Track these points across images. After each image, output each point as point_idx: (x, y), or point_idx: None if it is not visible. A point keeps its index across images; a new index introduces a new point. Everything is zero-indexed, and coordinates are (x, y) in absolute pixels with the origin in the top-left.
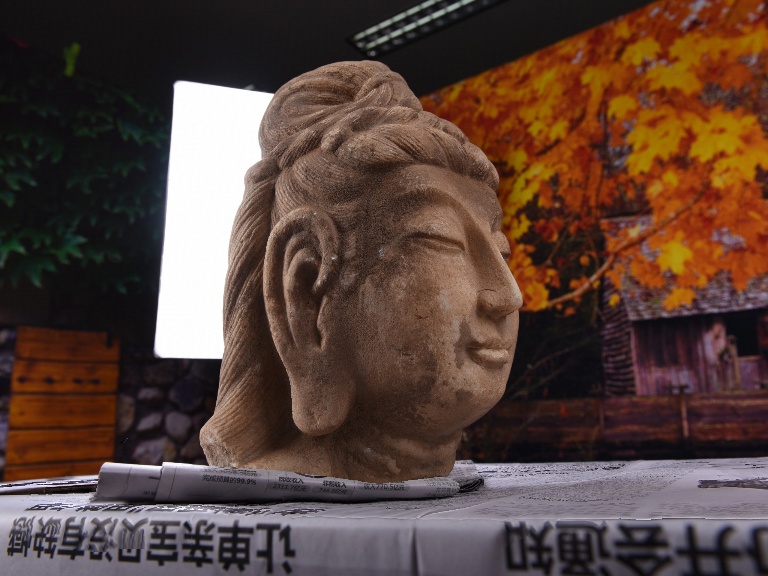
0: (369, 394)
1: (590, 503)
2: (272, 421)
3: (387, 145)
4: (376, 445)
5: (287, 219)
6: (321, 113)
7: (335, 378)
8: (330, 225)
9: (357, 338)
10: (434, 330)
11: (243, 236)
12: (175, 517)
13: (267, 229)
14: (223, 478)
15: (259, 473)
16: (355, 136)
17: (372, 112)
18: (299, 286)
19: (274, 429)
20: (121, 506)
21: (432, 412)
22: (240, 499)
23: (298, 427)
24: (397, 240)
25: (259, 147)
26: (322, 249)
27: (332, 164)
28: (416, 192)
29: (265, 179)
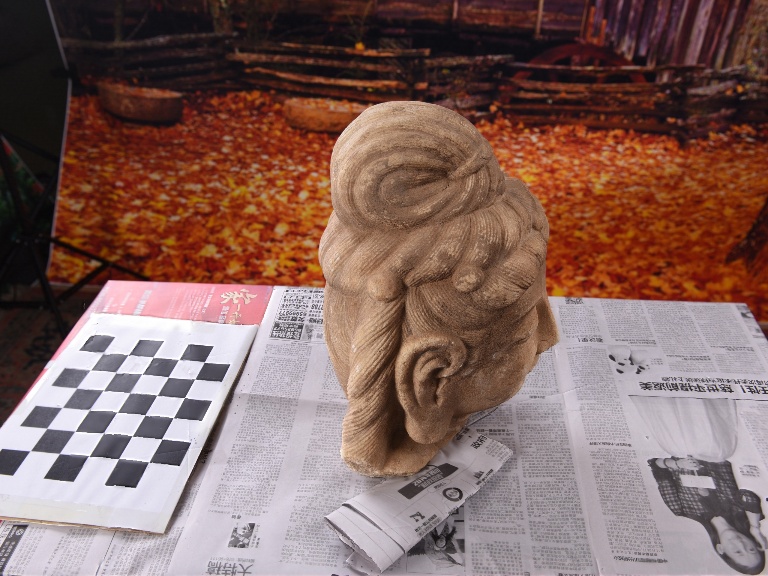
0: None
1: (652, 569)
2: None
3: (514, 292)
4: None
5: (427, 345)
6: (430, 212)
7: (445, 417)
8: None
9: (464, 396)
10: None
11: (382, 348)
12: None
13: (399, 337)
14: None
15: (439, 517)
16: (489, 283)
17: (496, 247)
18: (429, 378)
19: None
20: None
21: None
22: None
23: None
24: (506, 347)
25: (345, 211)
26: (453, 360)
27: (469, 306)
28: None
29: (396, 299)
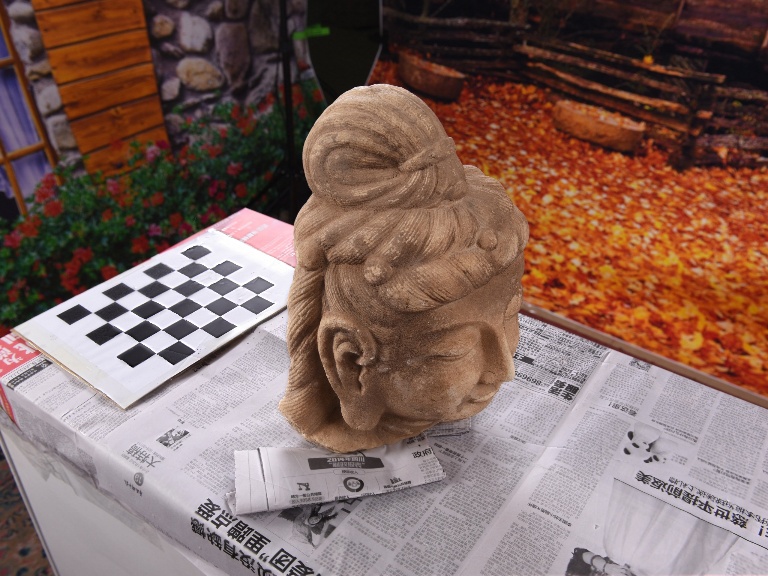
0: (394, 413)
1: None
2: (327, 404)
3: (420, 299)
4: (398, 425)
5: (336, 324)
6: (365, 196)
7: (371, 409)
8: (370, 340)
9: (387, 394)
10: (442, 405)
11: (300, 313)
12: None
13: (319, 309)
14: (303, 505)
15: (323, 496)
16: (394, 281)
17: (411, 248)
18: (346, 360)
19: (329, 408)
20: (253, 545)
21: None
22: None
23: None
24: (422, 358)
25: None
26: None
27: (373, 299)
28: (441, 329)
29: (315, 270)
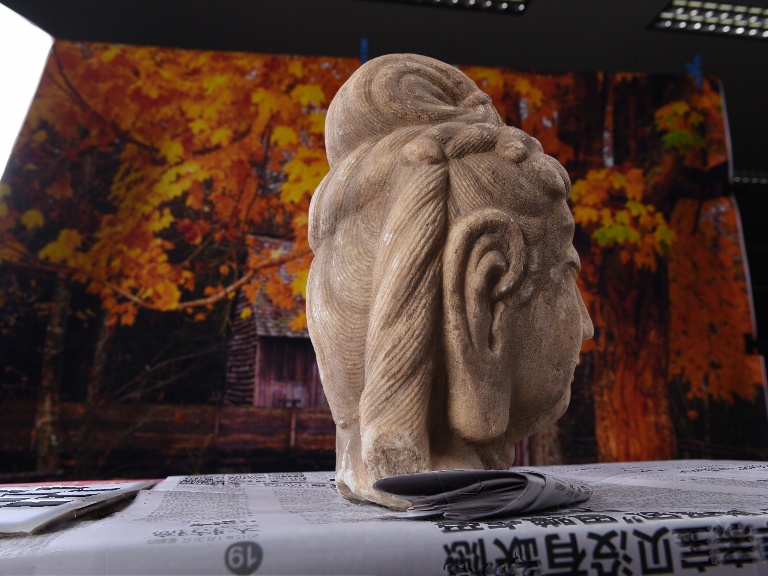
0: (517, 403)
1: None
2: (428, 424)
3: None
4: (501, 452)
5: (484, 217)
6: (454, 110)
7: (505, 385)
8: None
9: (523, 348)
10: None
11: (429, 219)
12: (701, 523)
13: (445, 218)
14: None
15: None
16: (535, 156)
17: None
18: (486, 287)
19: None
20: (594, 518)
21: (543, 423)
22: (545, 507)
23: (468, 432)
24: (562, 264)
25: (360, 112)
26: (512, 256)
27: (521, 176)
28: (571, 225)
29: (439, 163)
